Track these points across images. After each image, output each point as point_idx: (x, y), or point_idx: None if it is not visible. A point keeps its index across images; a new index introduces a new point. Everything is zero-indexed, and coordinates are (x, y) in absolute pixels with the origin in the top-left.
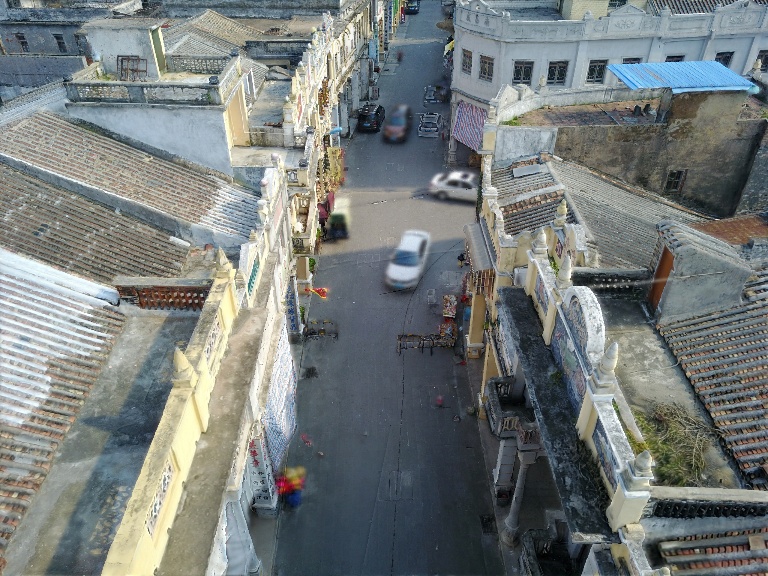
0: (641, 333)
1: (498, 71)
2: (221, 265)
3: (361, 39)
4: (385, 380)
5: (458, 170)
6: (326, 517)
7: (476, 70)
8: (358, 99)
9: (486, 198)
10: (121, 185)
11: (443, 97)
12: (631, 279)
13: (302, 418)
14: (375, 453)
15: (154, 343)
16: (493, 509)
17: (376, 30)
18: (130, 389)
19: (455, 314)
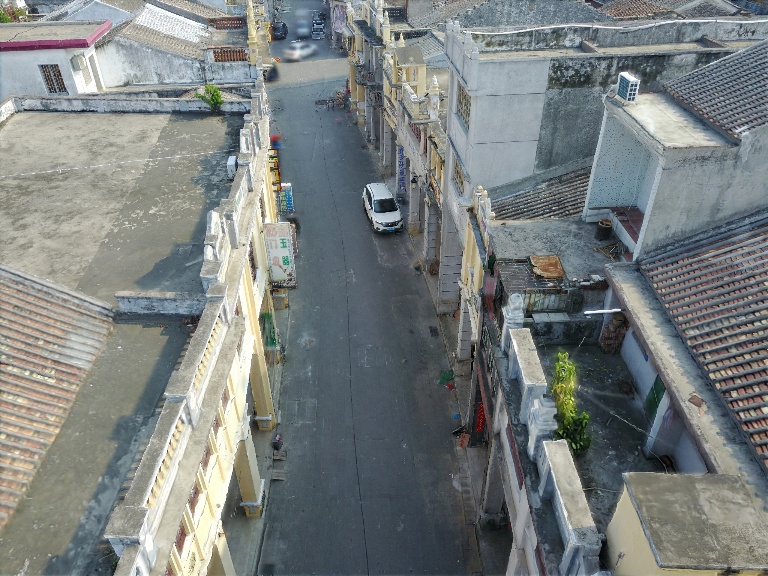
0: (402, 24)
1: None
2: (249, 5)
3: None
4: (311, 119)
5: (339, 51)
6: (293, 152)
7: None
8: (269, 20)
9: (349, 12)
10: (181, 7)
11: (325, 19)
12: (399, 10)
13: (273, 132)
14: (311, 137)
15: (227, 36)
16: (366, 144)
17: None
18: (225, 42)
19: (343, 96)
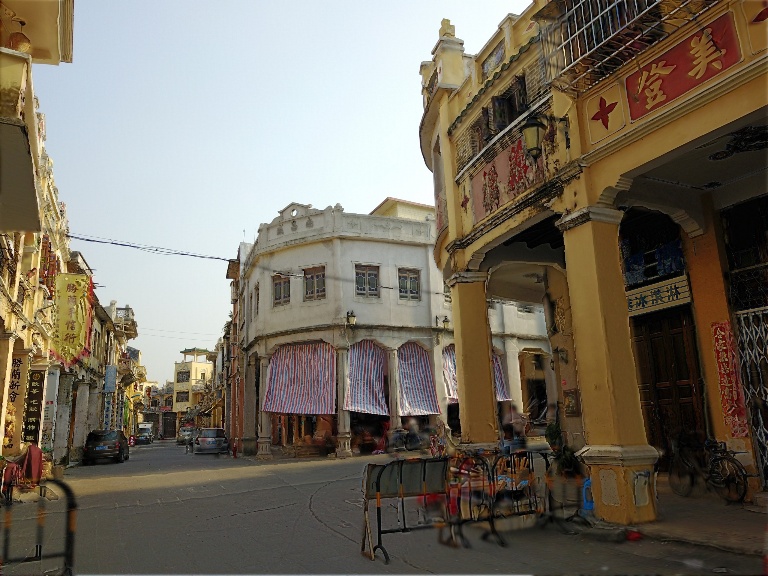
0: None
1: (334, 278)
2: None
3: (95, 359)
4: None
5: (280, 459)
6: None
7: (298, 291)
8: (84, 430)
9: None
10: None
11: None
12: None
13: None
14: None
15: None
16: None
17: (109, 394)
18: None
19: None
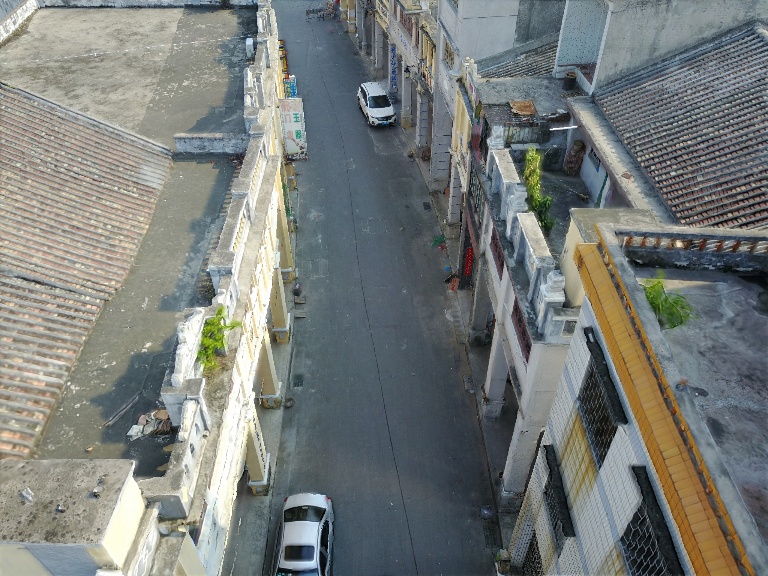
0: None
1: None
2: None
3: None
4: (303, 29)
5: None
6: None
7: None
8: None
9: None
10: None
11: None
12: None
13: None
14: (304, 45)
15: None
16: None
17: None
18: None
19: (333, 6)
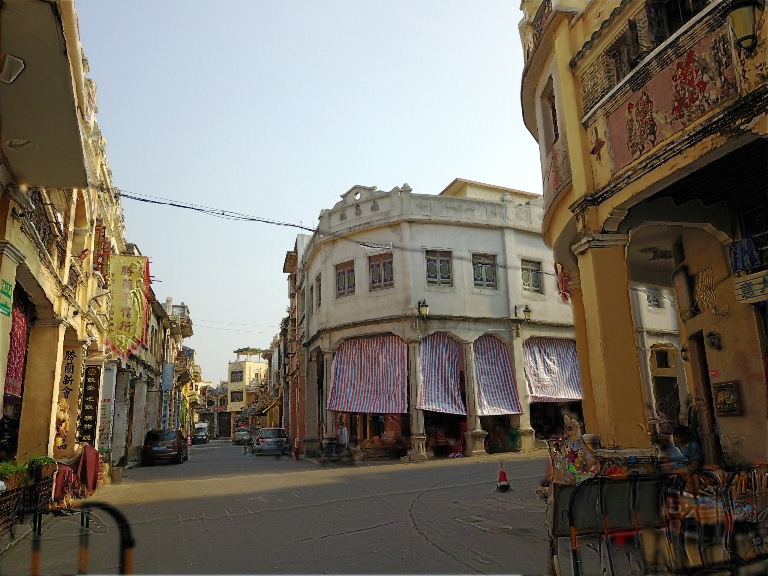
0: None
1: (403, 265)
2: None
3: (152, 356)
4: None
5: (348, 462)
6: None
7: (364, 280)
8: (143, 429)
9: None
10: None
11: None
12: None
13: None
14: None
15: None
16: None
17: None
18: None
19: None
